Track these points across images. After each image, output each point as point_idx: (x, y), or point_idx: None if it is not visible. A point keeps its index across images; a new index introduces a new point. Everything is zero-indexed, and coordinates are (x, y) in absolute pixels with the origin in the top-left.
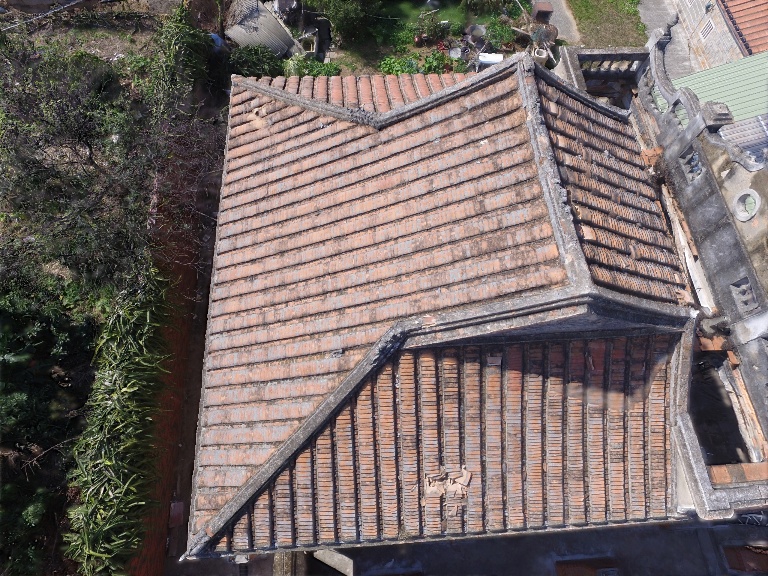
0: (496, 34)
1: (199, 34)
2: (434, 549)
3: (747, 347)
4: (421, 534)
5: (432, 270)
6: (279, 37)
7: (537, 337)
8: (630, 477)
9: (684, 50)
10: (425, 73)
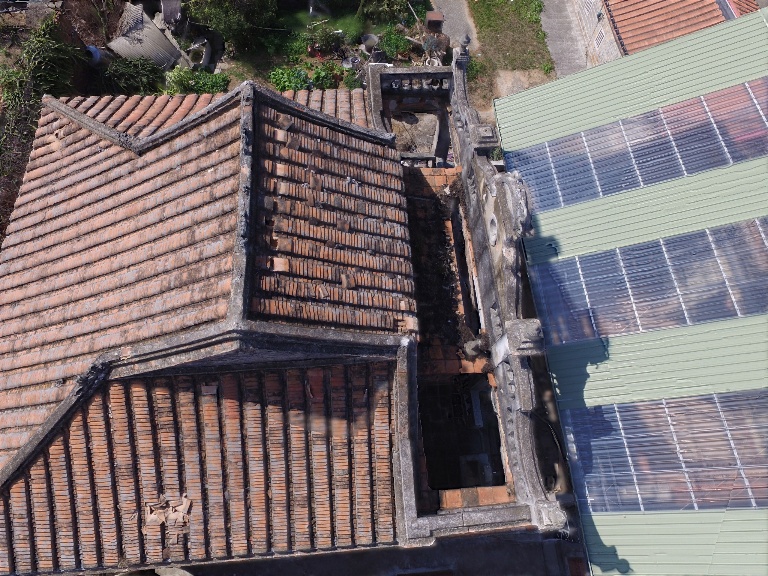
0: (391, 43)
1: (67, 48)
2: (277, 564)
3: (498, 370)
4: (144, 562)
5: (146, 300)
6: (165, 49)
7: (248, 366)
8: (356, 503)
9: (581, 58)
10: (313, 84)
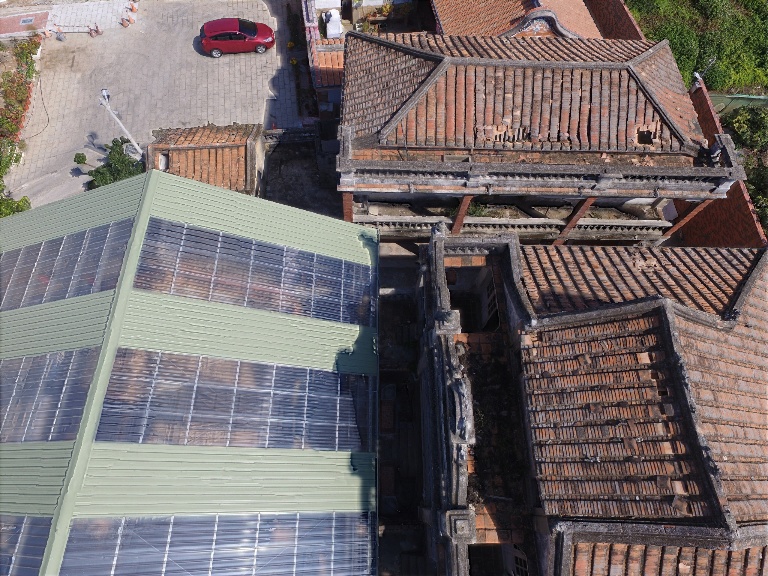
0: None
1: None
2: None
3: None
4: None
5: None
6: None
7: None
8: None
9: None
10: None
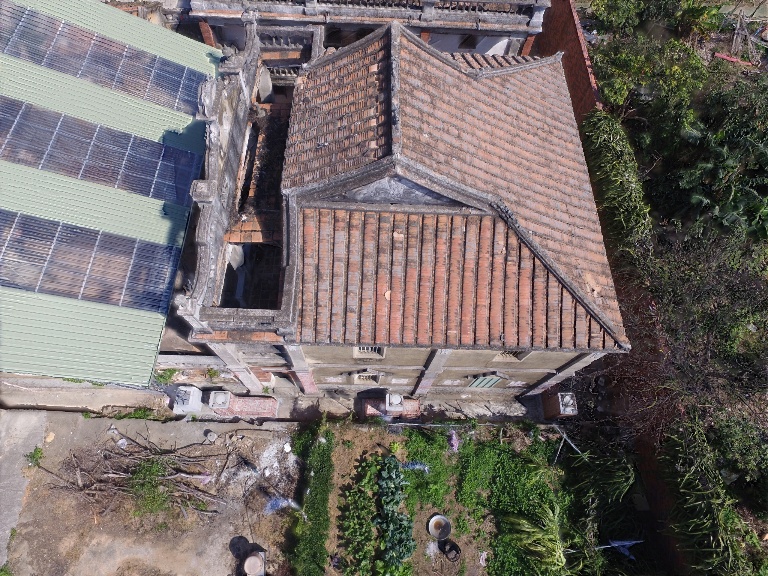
0: None
1: None
2: None
3: None
4: None
5: None
6: None
7: None
8: None
9: None
10: None
